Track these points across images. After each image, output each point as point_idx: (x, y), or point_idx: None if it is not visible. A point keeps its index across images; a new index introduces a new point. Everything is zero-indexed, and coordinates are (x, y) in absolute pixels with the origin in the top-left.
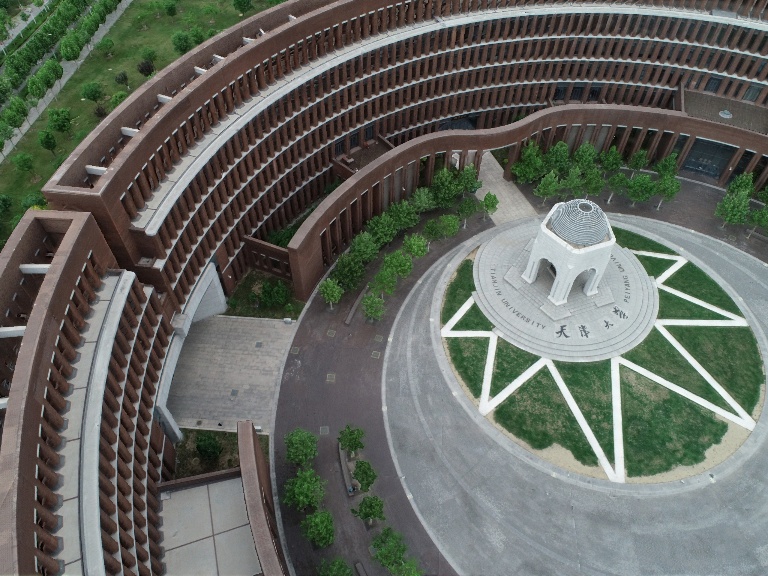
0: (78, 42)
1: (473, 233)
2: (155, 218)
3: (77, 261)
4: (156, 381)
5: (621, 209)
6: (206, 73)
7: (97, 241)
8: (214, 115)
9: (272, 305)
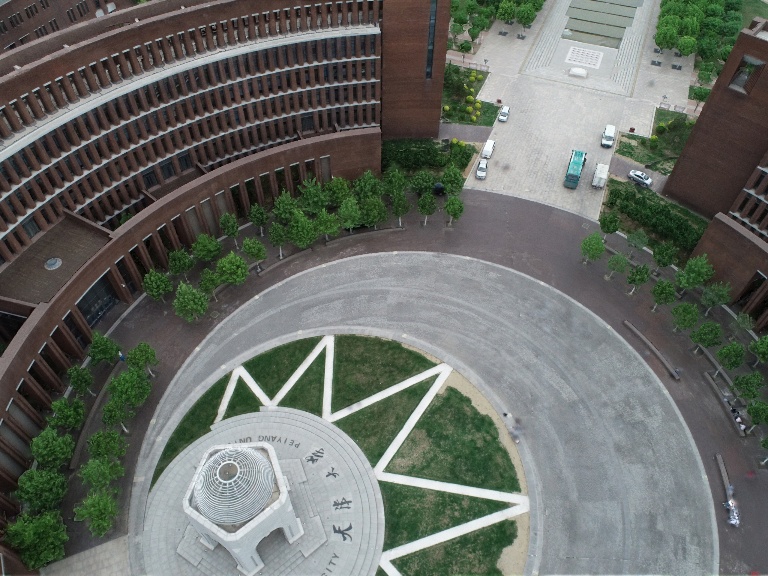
0: None
1: None
2: None
3: None
4: None
5: (143, 418)
6: None
7: None
8: None
9: None
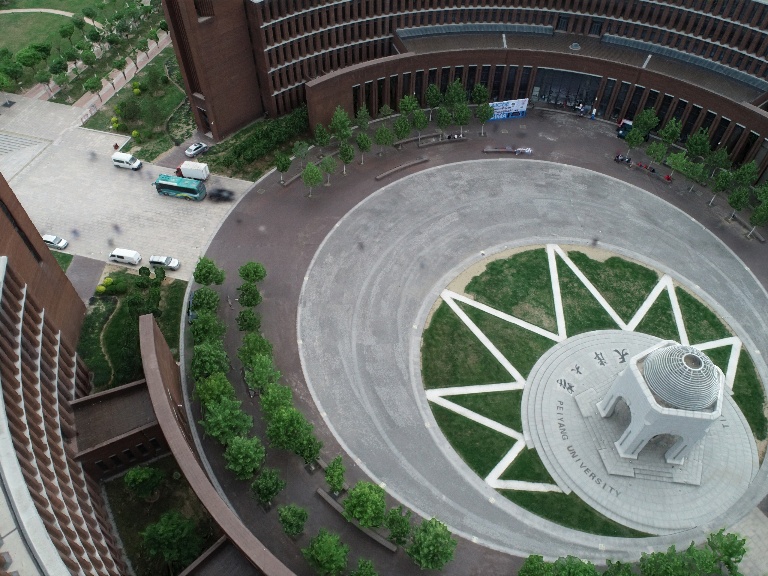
0: None
1: None
2: None
3: None
4: None
5: None
6: None
7: None
8: None
9: None
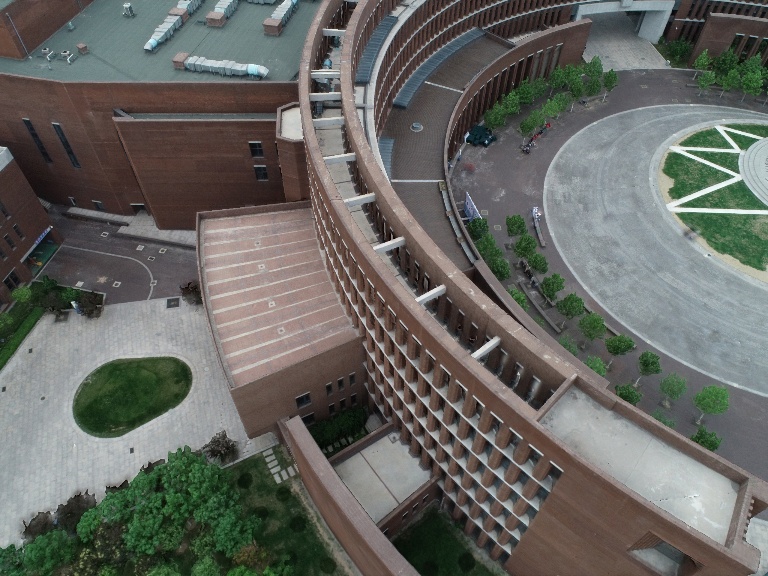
0: None
1: None
2: None
3: None
4: None
5: None
6: None
7: None
8: None
9: (673, 52)
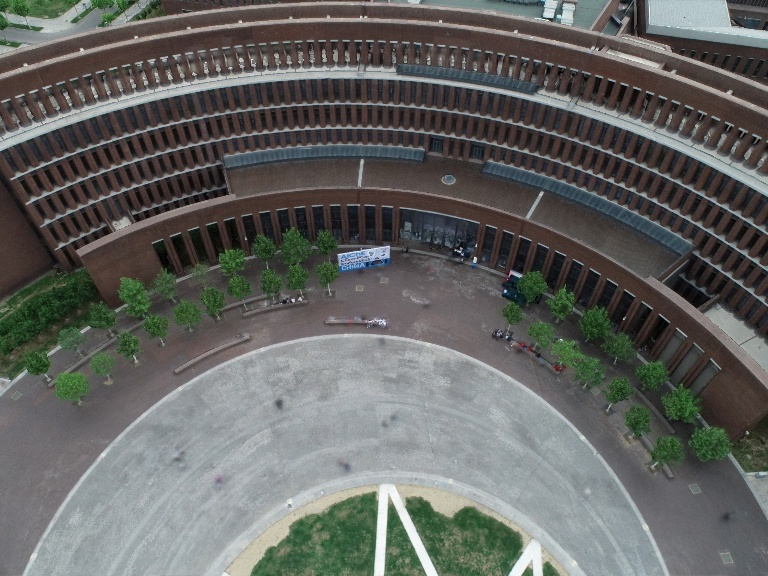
0: None
1: None
2: None
3: None
4: None
5: None
6: None
7: None
8: None
9: None
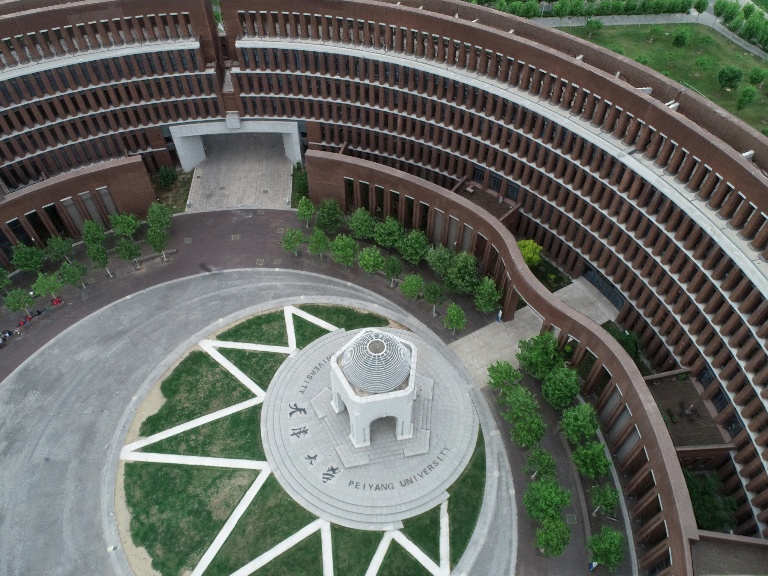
0: (575, 7)
1: (429, 323)
2: (250, 42)
3: (169, 6)
4: (183, 119)
5: None
6: (375, 1)
7: (198, 13)
8: (366, 36)
9: None
